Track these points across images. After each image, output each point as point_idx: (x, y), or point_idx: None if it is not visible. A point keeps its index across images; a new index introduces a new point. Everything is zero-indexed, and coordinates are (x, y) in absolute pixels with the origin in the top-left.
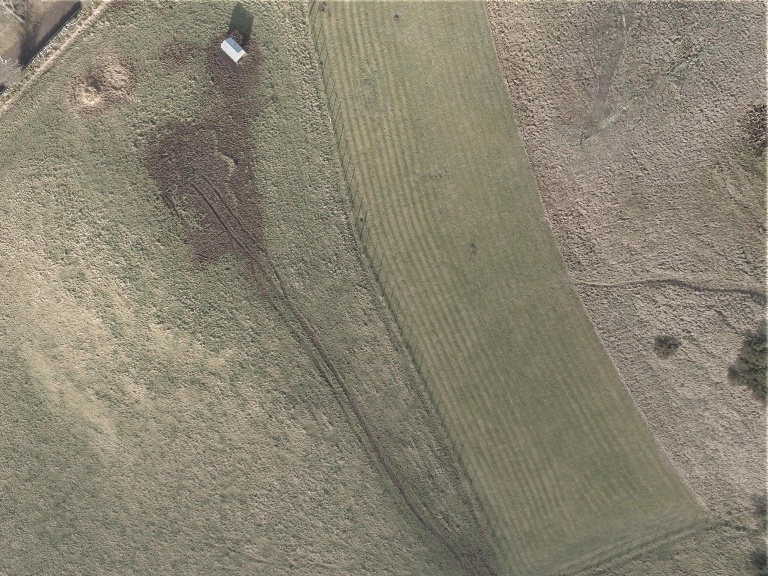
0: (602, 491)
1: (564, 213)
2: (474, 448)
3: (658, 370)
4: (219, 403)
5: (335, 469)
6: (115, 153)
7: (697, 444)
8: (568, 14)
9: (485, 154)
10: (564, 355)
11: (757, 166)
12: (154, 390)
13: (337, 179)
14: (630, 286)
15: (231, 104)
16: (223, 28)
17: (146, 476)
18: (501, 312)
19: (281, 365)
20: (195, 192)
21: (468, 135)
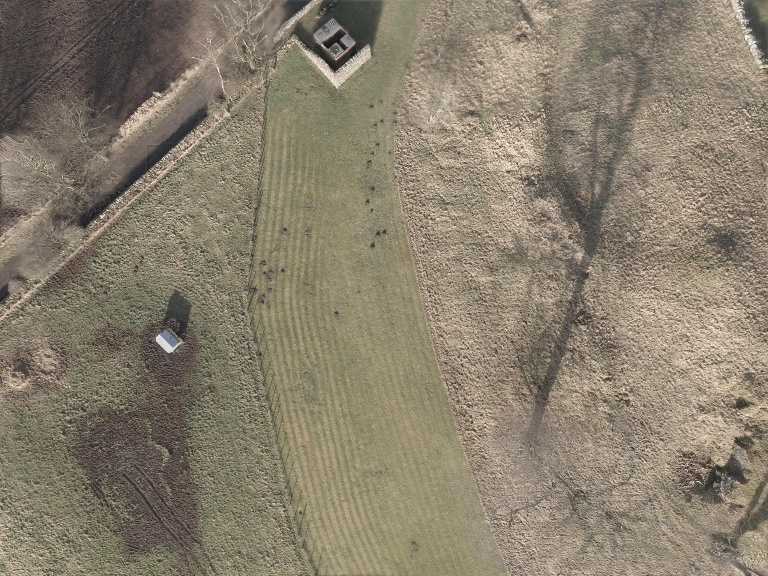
0: None
1: (504, 518)
2: None
3: None
4: None
5: None
6: (42, 440)
7: None
8: (505, 329)
9: (425, 454)
10: None
11: (687, 511)
12: None
13: (275, 471)
14: None
15: (166, 392)
16: (159, 315)
17: None
18: None
19: None
20: (127, 482)
21: (408, 434)
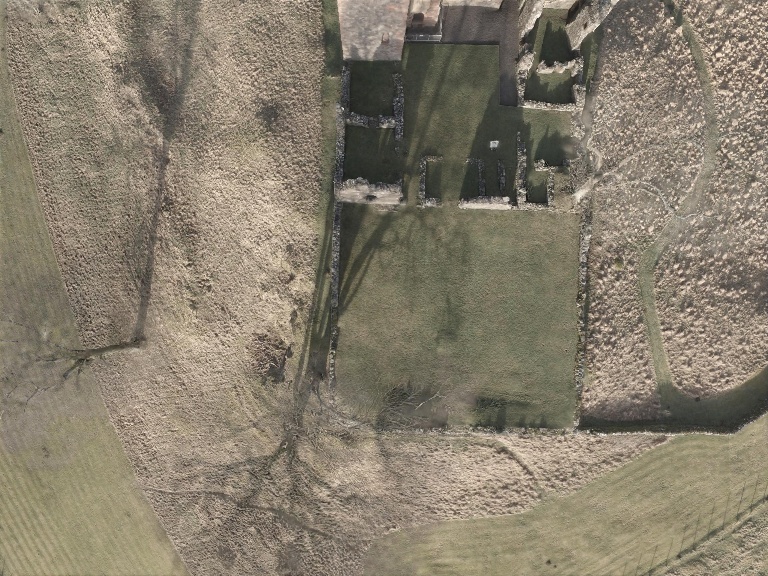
0: None
1: (127, 419)
2: None
3: None
4: None
5: None
6: None
7: None
8: (113, 224)
9: (49, 357)
10: (143, 560)
11: (263, 394)
12: None
13: None
14: (189, 495)
15: None
16: None
17: None
18: (79, 516)
19: None
20: None
21: (32, 338)
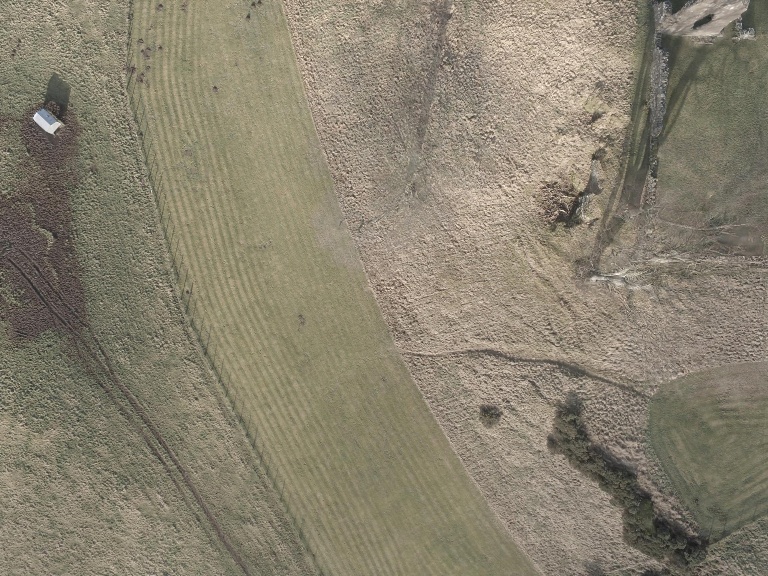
0: (443, 561)
1: (387, 283)
2: (315, 522)
3: (486, 438)
4: (47, 486)
5: (174, 550)
6: None
7: (529, 511)
8: (378, 88)
9: (307, 225)
10: (396, 425)
11: (552, 241)
12: None
13: (161, 251)
14: (452, 356)
15: (49, 176)
16: (39, 99)
17: None
18: (332, 383)
19: (110, 444)
20: (12, 267)
21: (290, 206)
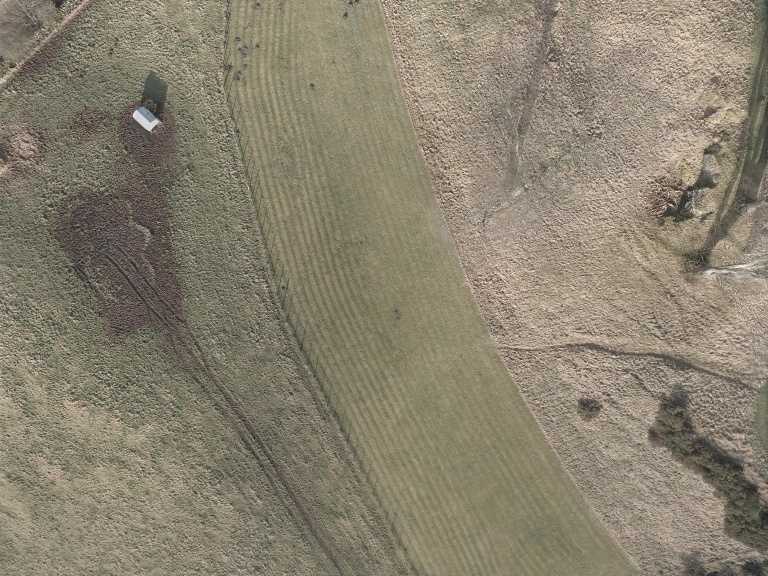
0: (536, 555)
1: (484, 278)
2: (407, 516)
3: (583, 432)
4: (140, 481)
5: (265, 544)
6: (24, 225)
7: (625, 504)
8: (478, 85)
9: (404, 220)
10: (492, 419)
11: (660, 235)
12: (70, 470)
13: (257, 247)
14: (551, 350)
15: (146, 173)
16: (136, 97)
17: (64, 561)
18: (427, 377)
19: (205, 439)
20: (109, 263)
21: (387, 202)
